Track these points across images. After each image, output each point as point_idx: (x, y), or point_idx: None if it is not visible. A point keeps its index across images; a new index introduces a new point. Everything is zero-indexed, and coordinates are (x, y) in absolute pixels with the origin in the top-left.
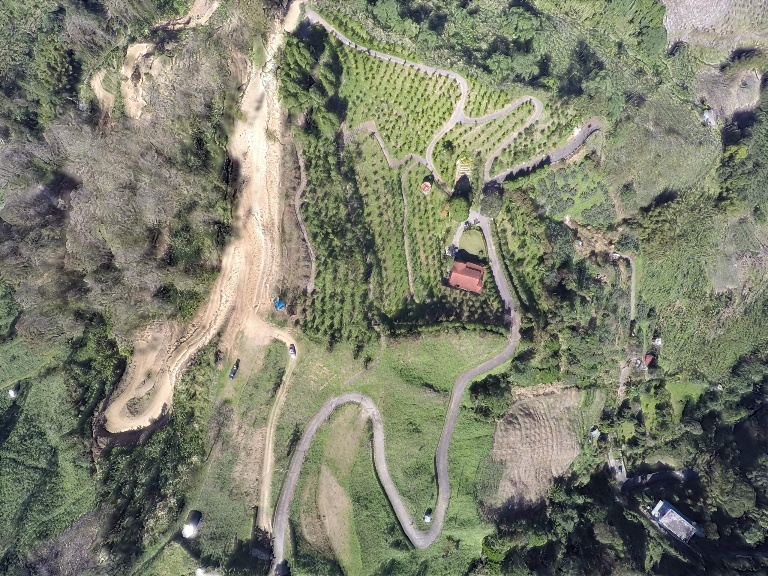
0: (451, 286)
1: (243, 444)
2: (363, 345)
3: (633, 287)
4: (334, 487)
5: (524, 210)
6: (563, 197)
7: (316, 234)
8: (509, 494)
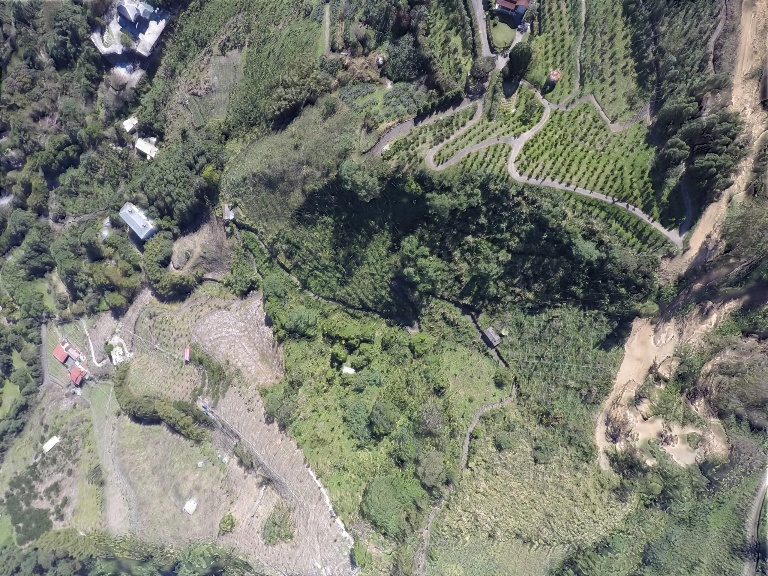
0: None
1: None
2: None
3: (328, 29)
4: None
5: None
6: None
7: None
8: None
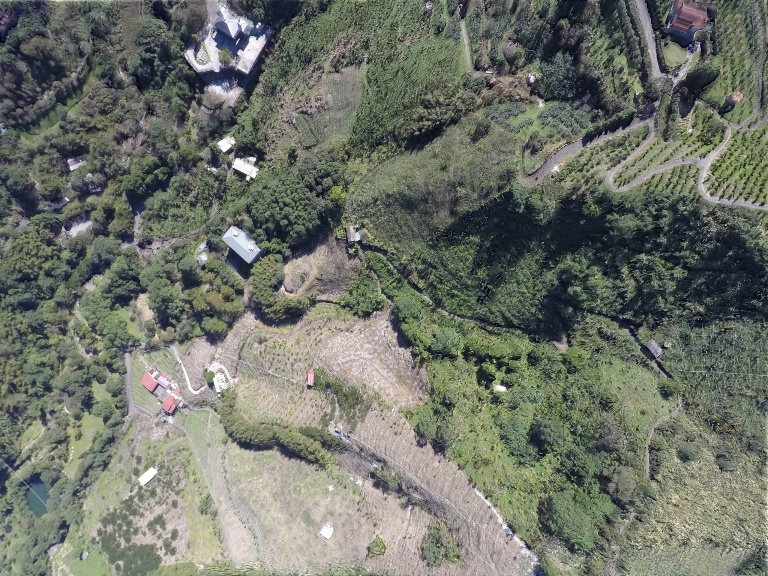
0: (705, 5)
1: None
2: None
3: (467, 46)
4: None
5: None
6: None
7: None
8: None
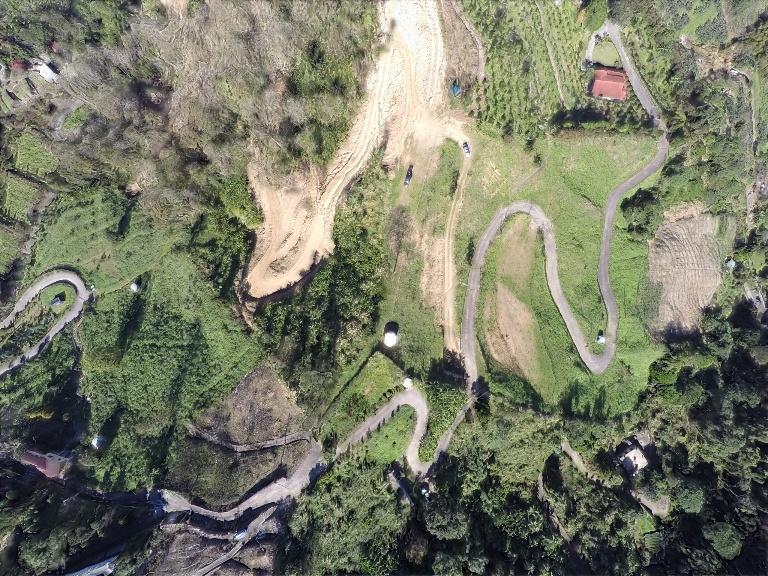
0: (594, 97)
1: (426, 255)
2: (534, 140)
3: (752, 106)
4: (514, 303)
5: (648, 22)
6: (678, 13)
7: (476, 25)
8: (668, 318)
